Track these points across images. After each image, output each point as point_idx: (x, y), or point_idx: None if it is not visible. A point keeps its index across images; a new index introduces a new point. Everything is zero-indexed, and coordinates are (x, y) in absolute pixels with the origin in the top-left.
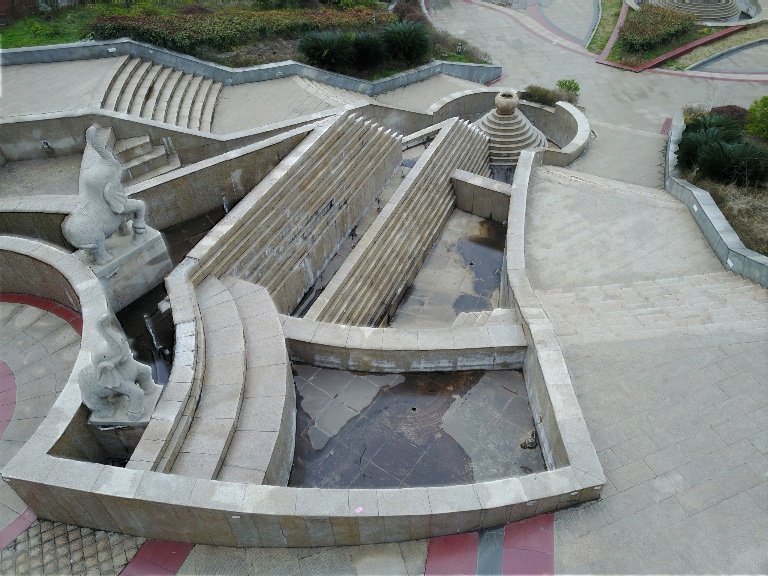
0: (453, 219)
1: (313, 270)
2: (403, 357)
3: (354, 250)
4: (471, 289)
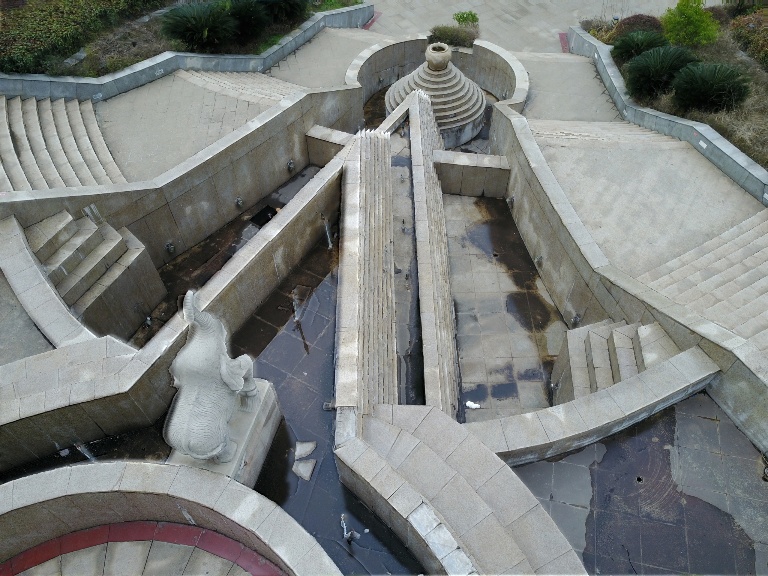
0: (445, 207)
1: None
2: (608, 427)
3: (422, 294)
4: (513, 285)
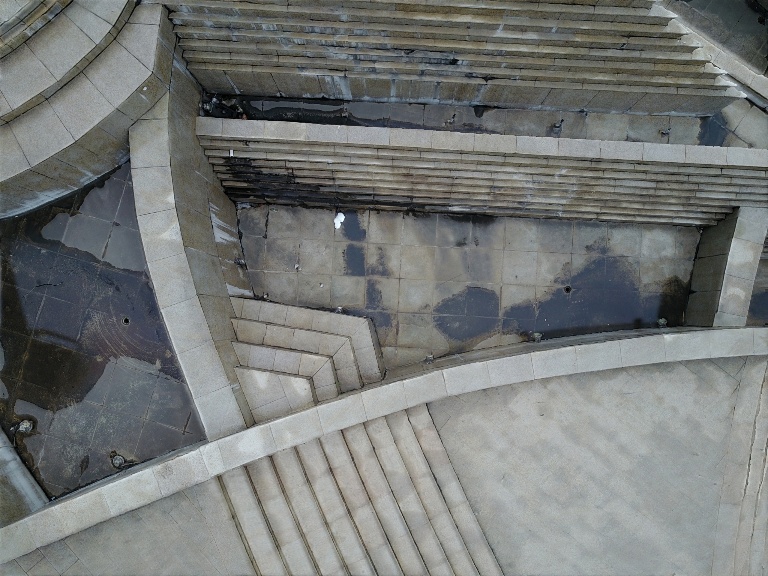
0: (671, 232)
1: (354, 91)
2: None
3: (419, 132)
4: (512, 302)
